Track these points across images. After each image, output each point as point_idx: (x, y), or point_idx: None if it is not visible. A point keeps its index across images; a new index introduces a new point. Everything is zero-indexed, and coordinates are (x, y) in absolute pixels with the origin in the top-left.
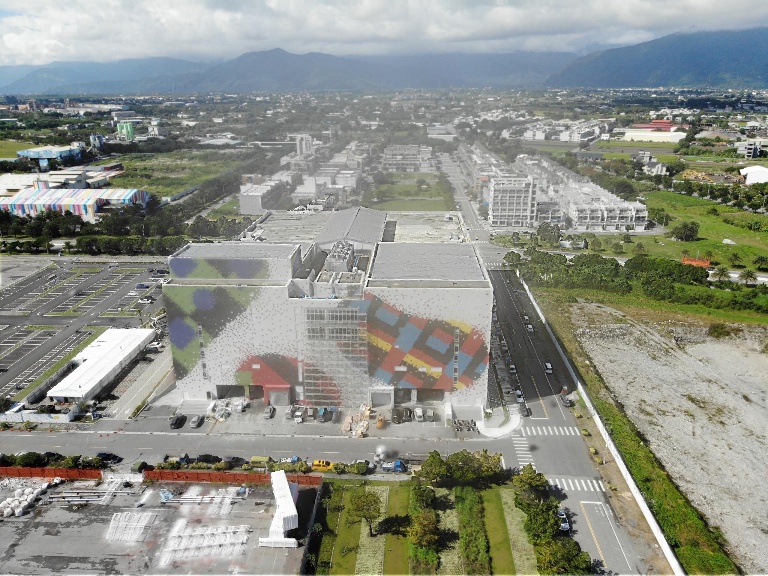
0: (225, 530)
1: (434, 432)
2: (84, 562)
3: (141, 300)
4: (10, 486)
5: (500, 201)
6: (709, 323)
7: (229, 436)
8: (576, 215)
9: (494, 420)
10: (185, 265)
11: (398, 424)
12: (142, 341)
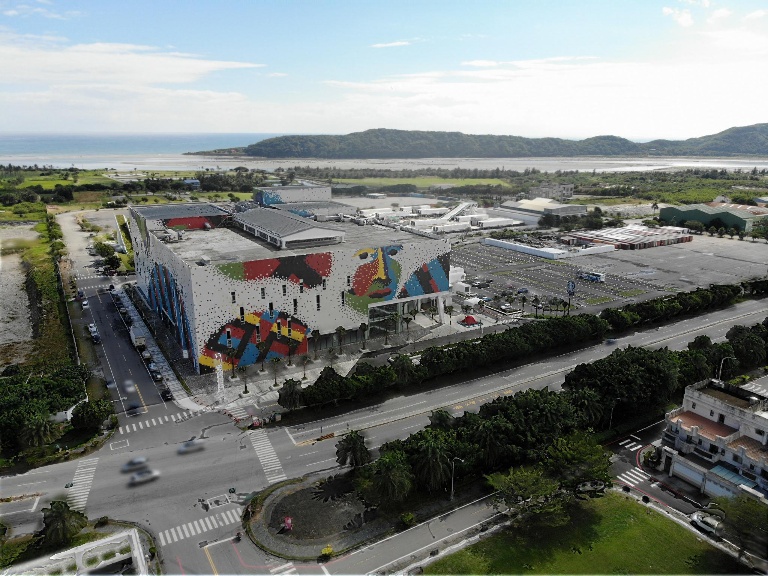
0: None
1: None
2: None
3: None
4: None
5: None
6: None
7: None
8: None
9: None
10: None
11: None
12: None
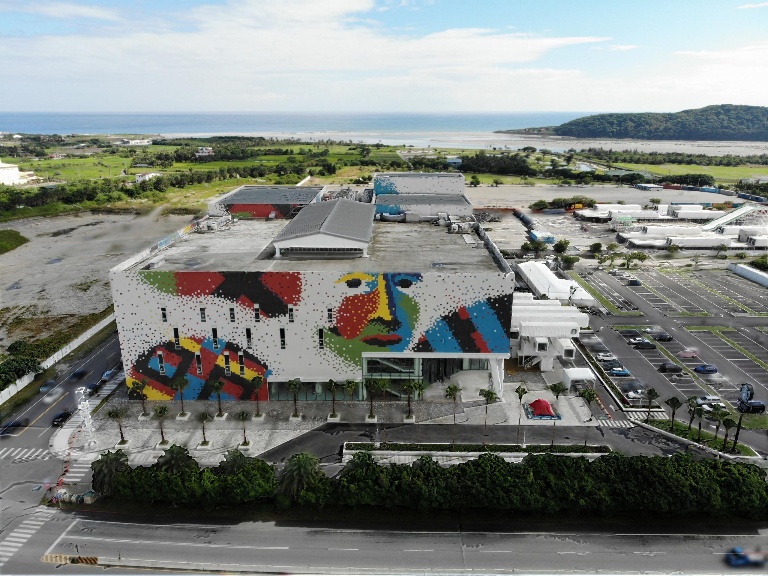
0: None
1: None
2: None
3: None
4: None
5: None
6: None
7: None
8: None
9: None
10: None
11: None
12: None
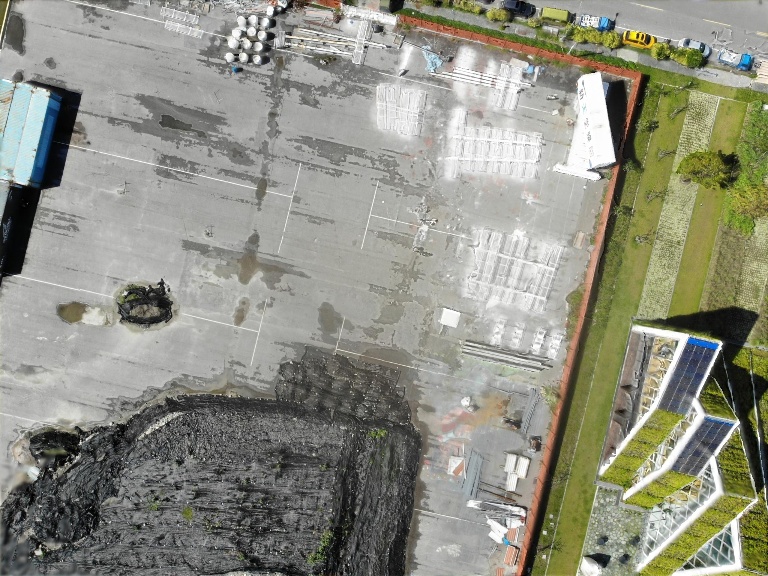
0: (514, 138)
1: None
2: (362, 156)
3: None
4: (223, 1)
5: None
6: None
7: None
8: None
9: None
10: None
11: None
12: None
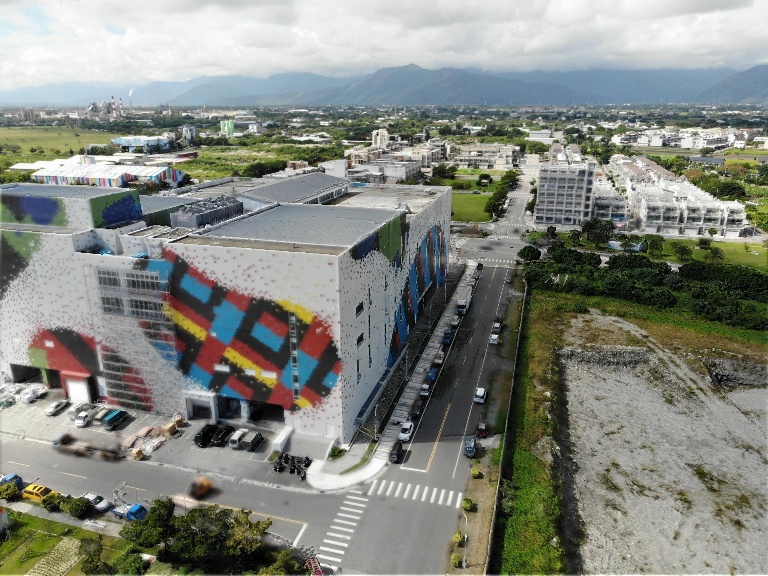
0: None
1: (241, 467)
2: None
3: None
4: None
5: (546, 191)
6: None
7: None
8: (645, 213)
9: (341, 462)
10: None
11: (202, 448)
12: None
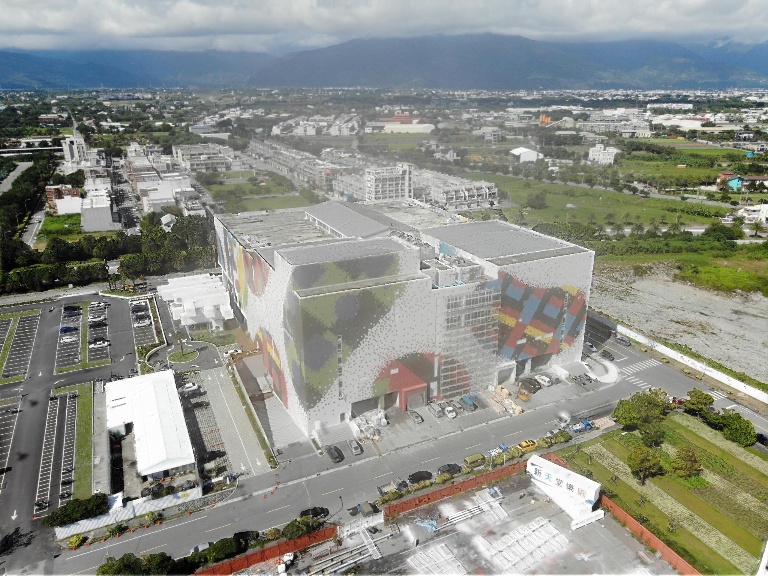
0: (529, 529)
1: (569, 391)
2: None
3: (93, 344)
4: None
5: (381, 189)
6: (631, 266)
7: (405, 450)
8: (444, 197)
9: (597, 369)
10: (310, 272)
11: (535, 393)
12: (175, 386)
